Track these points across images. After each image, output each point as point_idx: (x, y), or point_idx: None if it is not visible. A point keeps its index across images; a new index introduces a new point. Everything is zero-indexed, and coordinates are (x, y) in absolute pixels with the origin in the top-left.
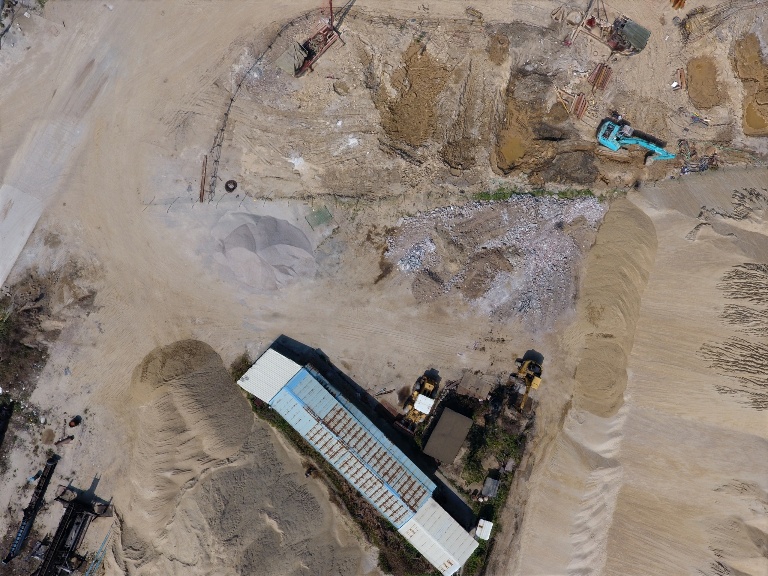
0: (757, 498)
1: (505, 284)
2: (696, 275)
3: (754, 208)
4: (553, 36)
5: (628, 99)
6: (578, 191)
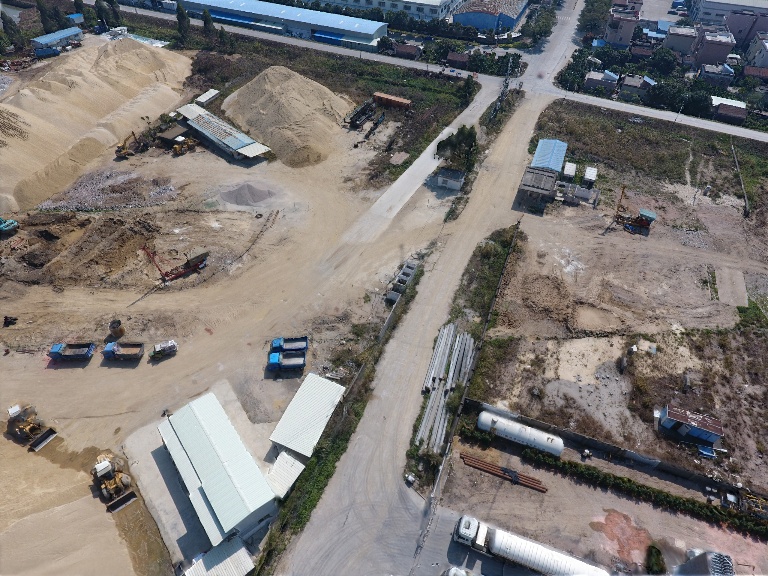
0: (39, 95)
1: None
2: (7, 163)
3: None
4: None
5: None
6: None
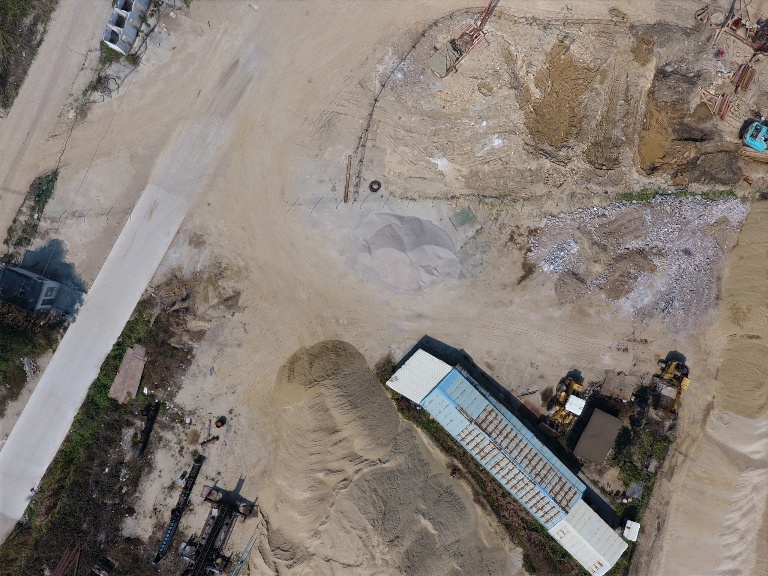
0: None
1: (648, 285)
2: None
3: None
4: (697, 37)
5: None
6: (720, 192)
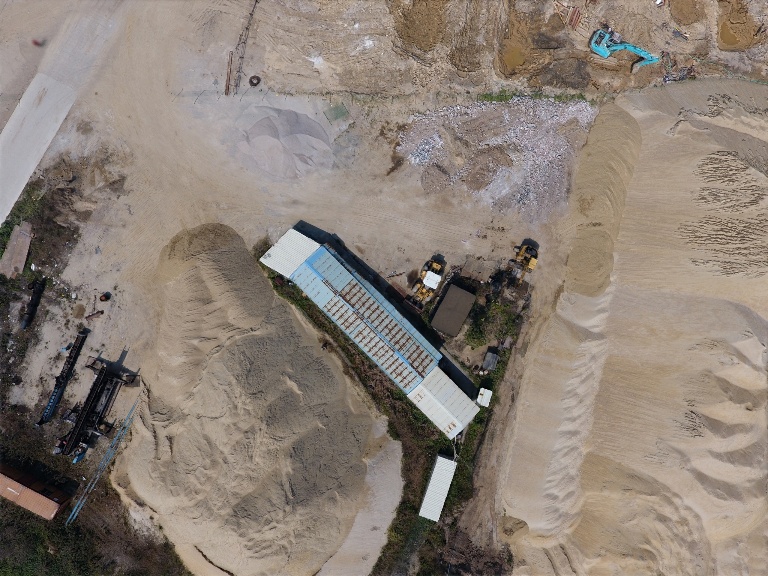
0: (725, 351)
1: (505, 178)
2: (675, 165)
3: (726, 107)
4: None
5: (617, 13)
6: (572, 95)
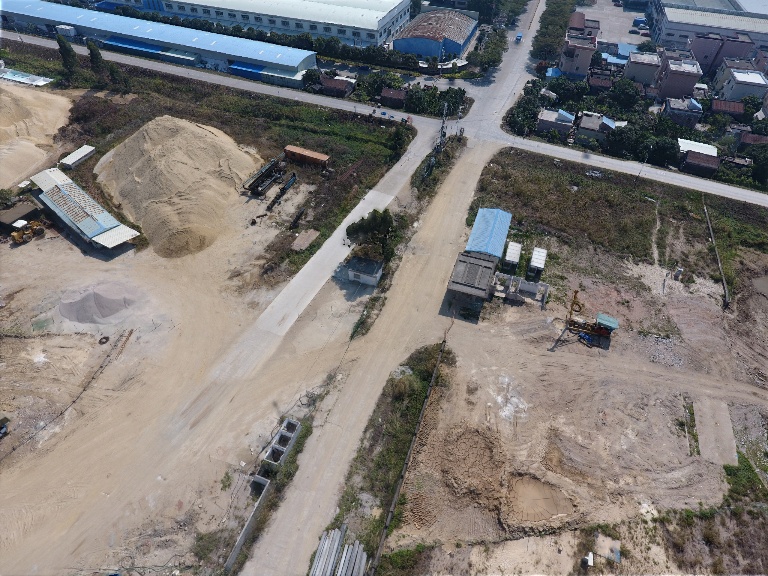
0: None
1: None
2: None
3: None
4: None
5: None
6: None
